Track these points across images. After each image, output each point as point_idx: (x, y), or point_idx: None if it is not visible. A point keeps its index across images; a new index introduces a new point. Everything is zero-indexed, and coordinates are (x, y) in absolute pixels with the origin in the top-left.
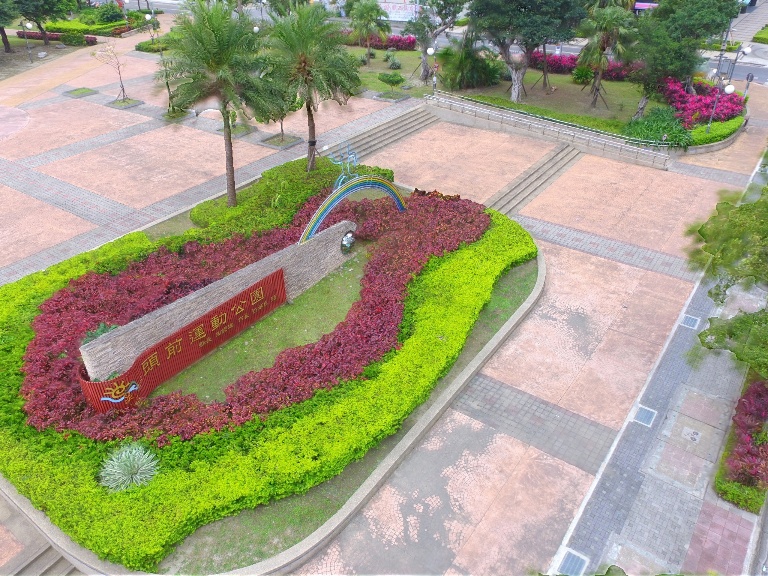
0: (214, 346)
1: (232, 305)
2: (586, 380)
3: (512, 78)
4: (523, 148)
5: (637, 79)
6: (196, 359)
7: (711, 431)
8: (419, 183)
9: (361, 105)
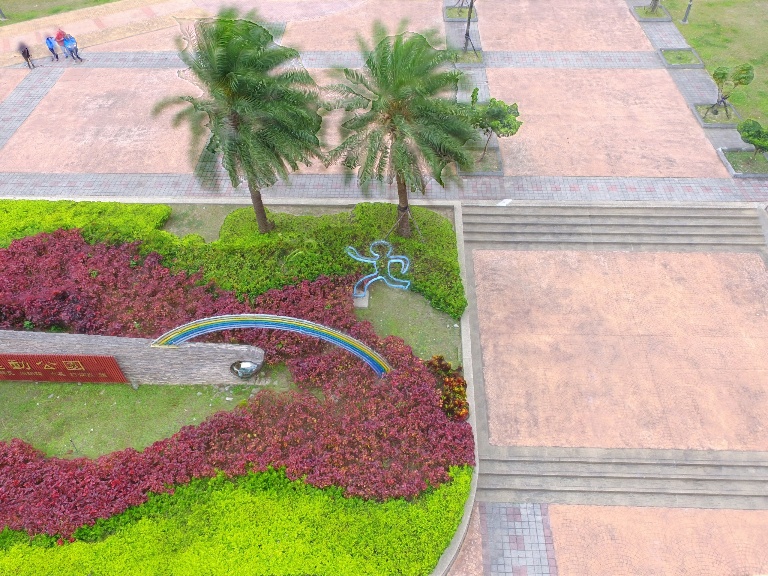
0: (23, 379)
1: (38, 360)
2: None
3: None
4: None
5: None
6: (1, 379)
7: None
8: (517, 339)
9: (679, 153)
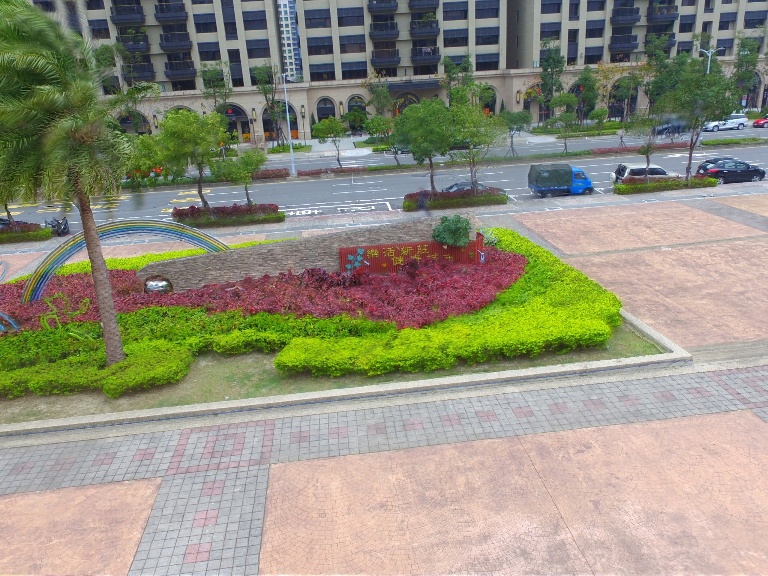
0: None
1: None
2: (233, 243)
3: None
4: None
5: None
6: None
7: (243, 227)
8: None
9: None
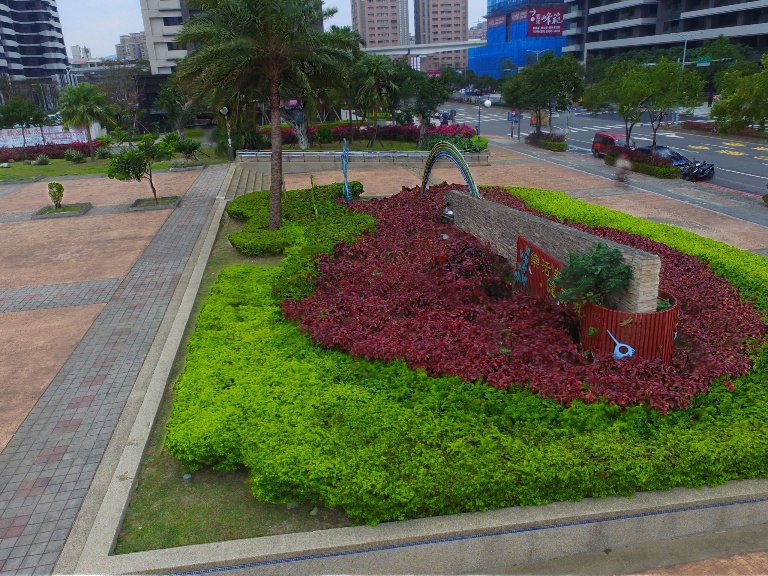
0: None
1: None
2: (742, 235)
3: (296, 133)
4: (382, 171)
5: (416, 110)
6: None
7: None
8: None
9: (168, 176)
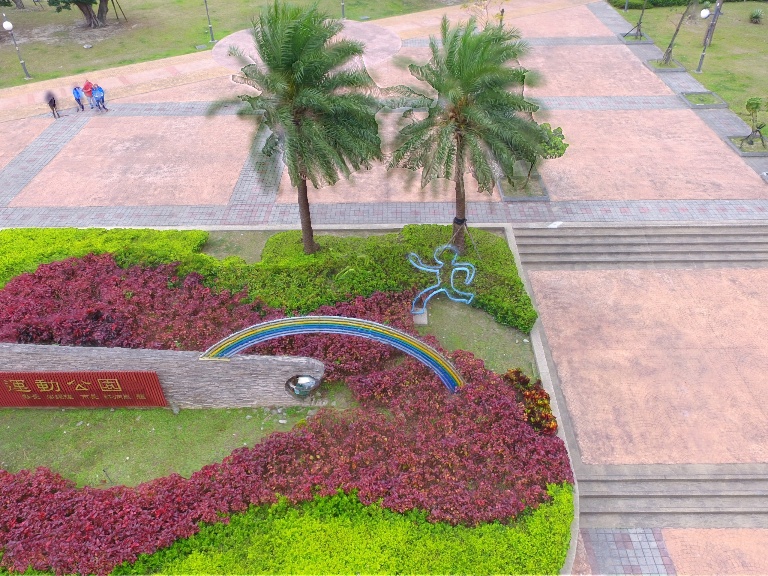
0: (48, 404)
1: (70, 379)
2: None
3: None
4: None
5: None
6: None
7: None
8: (592, 355)
9: (724, 178)
